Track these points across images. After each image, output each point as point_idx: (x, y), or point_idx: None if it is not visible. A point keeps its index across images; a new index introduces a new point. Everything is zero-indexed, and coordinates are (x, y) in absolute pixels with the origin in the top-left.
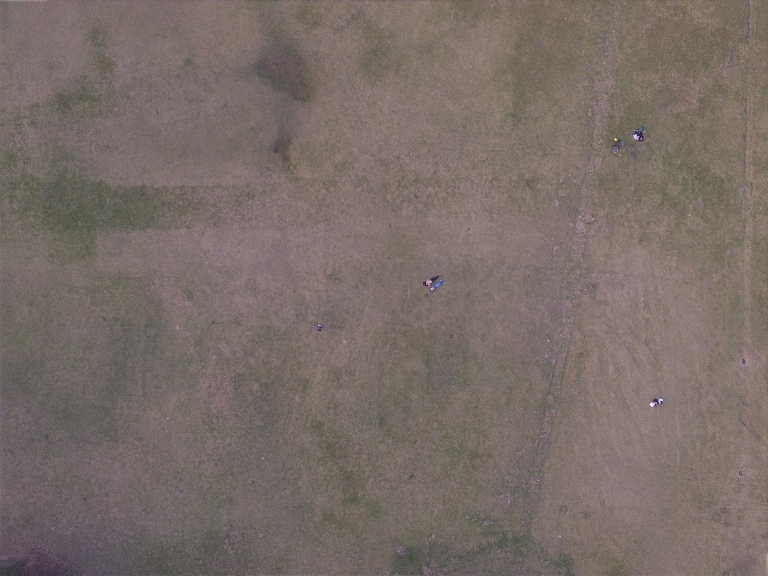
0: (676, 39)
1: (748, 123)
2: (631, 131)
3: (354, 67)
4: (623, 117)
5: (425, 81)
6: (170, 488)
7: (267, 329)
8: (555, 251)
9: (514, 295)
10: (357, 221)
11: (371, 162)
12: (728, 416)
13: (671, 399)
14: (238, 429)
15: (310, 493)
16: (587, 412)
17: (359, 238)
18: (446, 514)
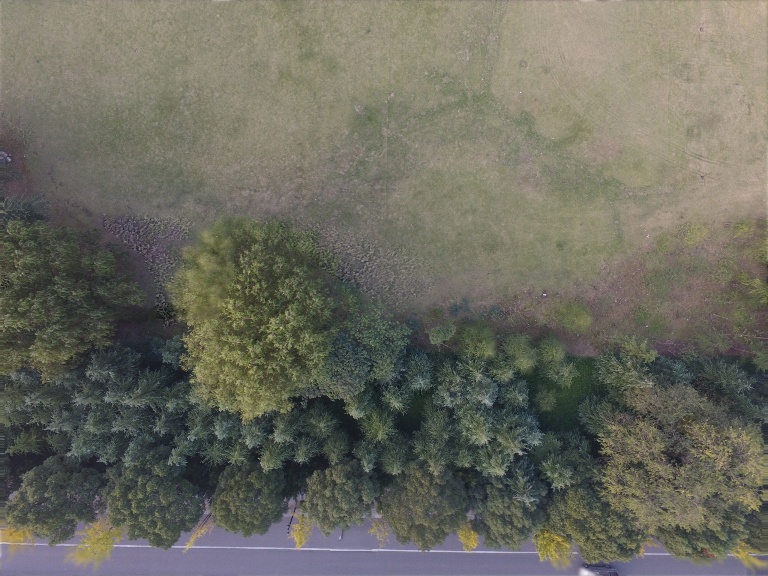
0: None
1: None
2: None
3: None
4: None
5: None
6: (124, 48)
7: None
8: None
9: None
10: None
11: None
12: None
13: None
14: None
15: (266, 50)
16: None
17: None
18: (404, 70)
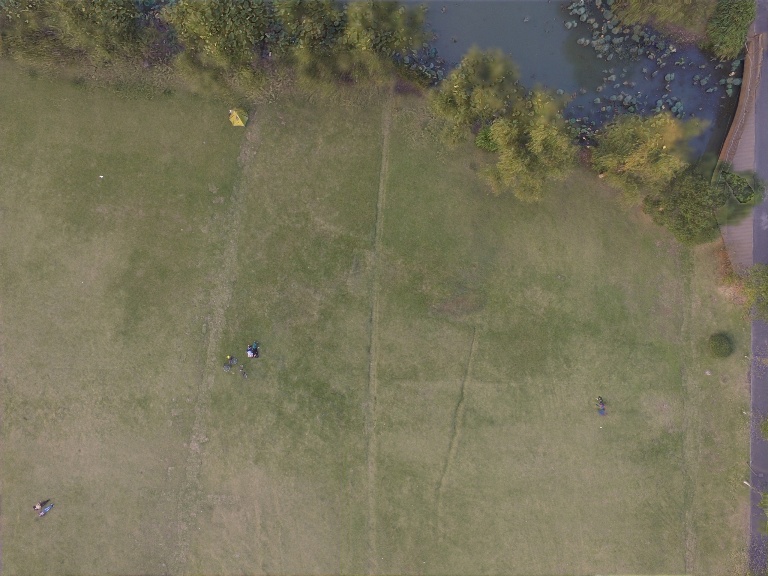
0: (297, 248)
1: (373, 334)
2: (246, 347)
3: None
4: (238, 332)
5: (34, 300)
6: None
7: None
8: (170, 472)
9: (128, 518)
10: None
11: None
12: None
13: None
14: None
15: None
16: None
17: None
18: None
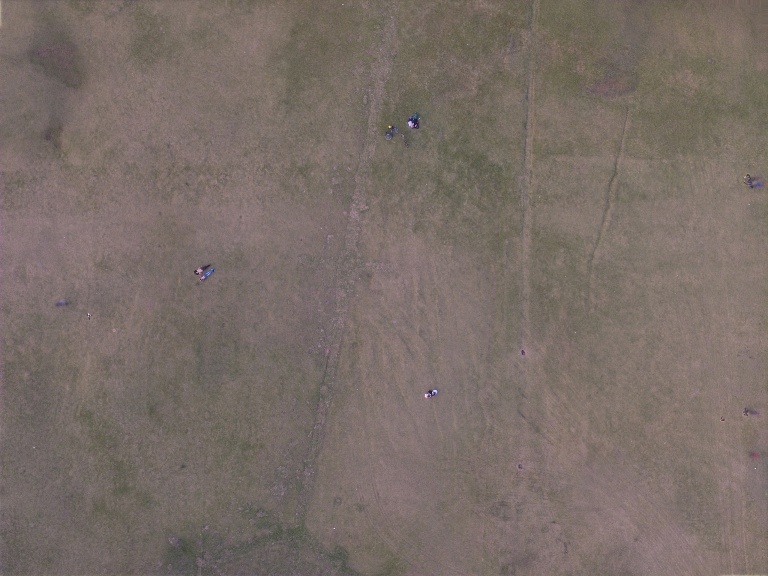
0: (456, 25)
1: (529, 110)
2: (406, 118)
3: (126, 53)
4: (398, 104)
5: (197, 67)
6: None
7: (37, 317)
8: (329, 240)
9: (287, 284)
10: (127, 209)
11: (141, 149)
12: (507, 408)
13: (447, 390)
14: (9, 418)
15: (81, 483)
16: (361, 403)
17: (129, 226)
18: (218, 505)
